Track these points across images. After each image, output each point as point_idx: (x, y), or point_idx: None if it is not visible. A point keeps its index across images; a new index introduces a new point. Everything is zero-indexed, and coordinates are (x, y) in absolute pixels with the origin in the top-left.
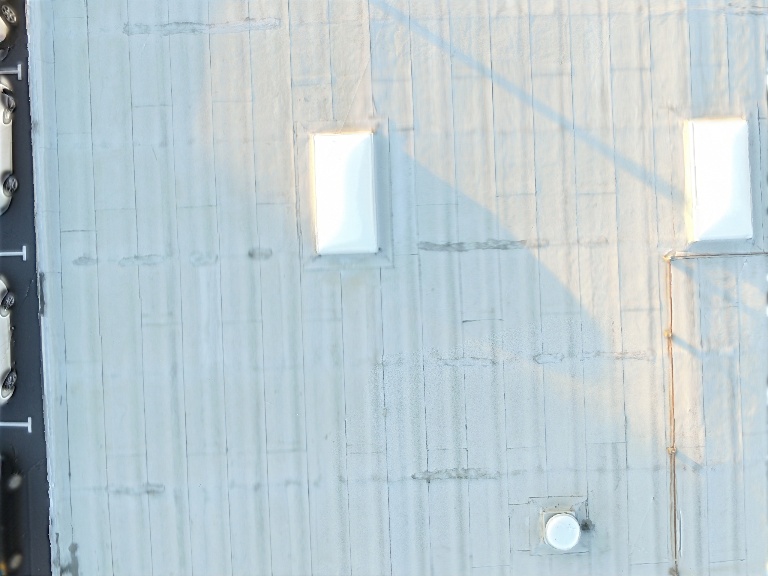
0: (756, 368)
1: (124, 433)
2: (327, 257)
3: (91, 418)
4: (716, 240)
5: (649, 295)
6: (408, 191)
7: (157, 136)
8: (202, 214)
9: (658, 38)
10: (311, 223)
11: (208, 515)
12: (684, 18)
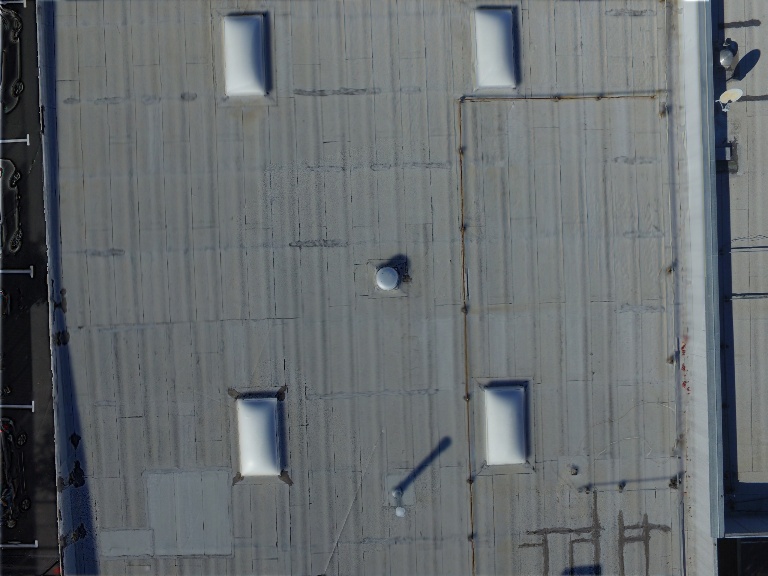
0: (520, 175)
1: (97, 215)
2: (233, 98)
3: (75, 205)
4: (491, 89)
5: (448, 126)
6: (287, 55)
7: (120, 18)
8: (150, 70)
9: None
10: (222, 76)
11: (153, 270)
12: None
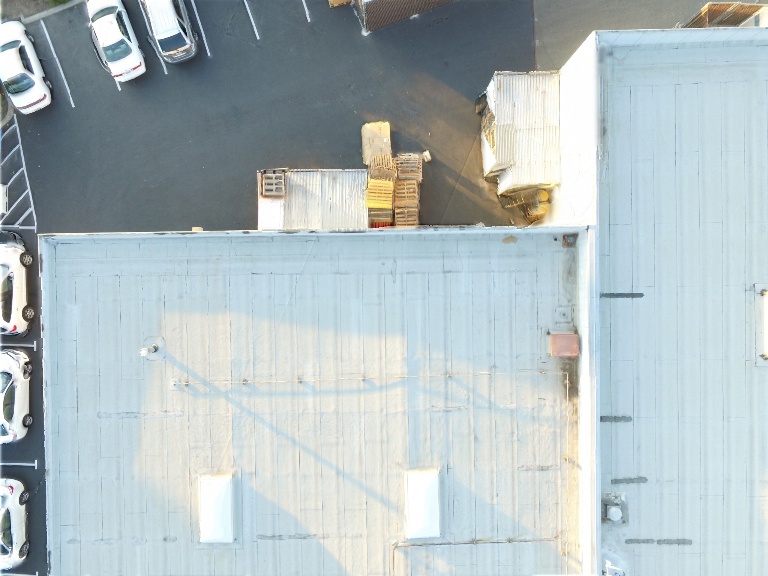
0: None
1: None
2: (206, 543)
3: None
4: None
5: (384, 566)
6: (252, 507)
7: (115, 474)
8: (138, 517)
9: (391, 425)
10: (198, 524)
11: None
12: (406, 415)
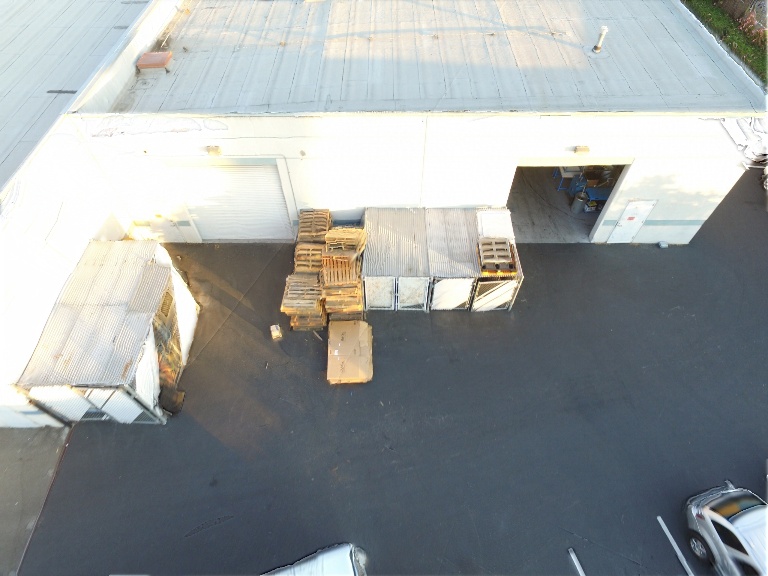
0: None
1: None
2: None
3: None
4: None
5: None
6: None
7: None
8: None
9: None
10: None
11: None
12: None
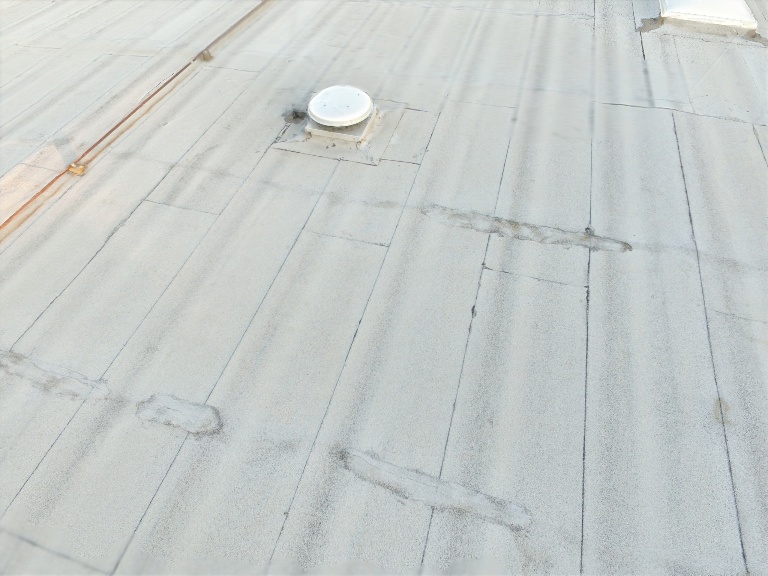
0: None
1: None
2: None
3: None
4: None
5: None
6: None
7: None
8: None
9: None
10: None
11: None
12: None
